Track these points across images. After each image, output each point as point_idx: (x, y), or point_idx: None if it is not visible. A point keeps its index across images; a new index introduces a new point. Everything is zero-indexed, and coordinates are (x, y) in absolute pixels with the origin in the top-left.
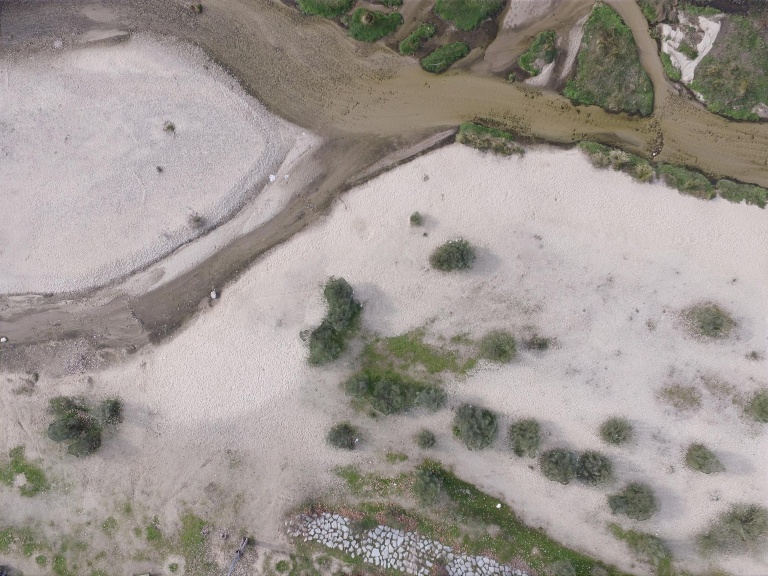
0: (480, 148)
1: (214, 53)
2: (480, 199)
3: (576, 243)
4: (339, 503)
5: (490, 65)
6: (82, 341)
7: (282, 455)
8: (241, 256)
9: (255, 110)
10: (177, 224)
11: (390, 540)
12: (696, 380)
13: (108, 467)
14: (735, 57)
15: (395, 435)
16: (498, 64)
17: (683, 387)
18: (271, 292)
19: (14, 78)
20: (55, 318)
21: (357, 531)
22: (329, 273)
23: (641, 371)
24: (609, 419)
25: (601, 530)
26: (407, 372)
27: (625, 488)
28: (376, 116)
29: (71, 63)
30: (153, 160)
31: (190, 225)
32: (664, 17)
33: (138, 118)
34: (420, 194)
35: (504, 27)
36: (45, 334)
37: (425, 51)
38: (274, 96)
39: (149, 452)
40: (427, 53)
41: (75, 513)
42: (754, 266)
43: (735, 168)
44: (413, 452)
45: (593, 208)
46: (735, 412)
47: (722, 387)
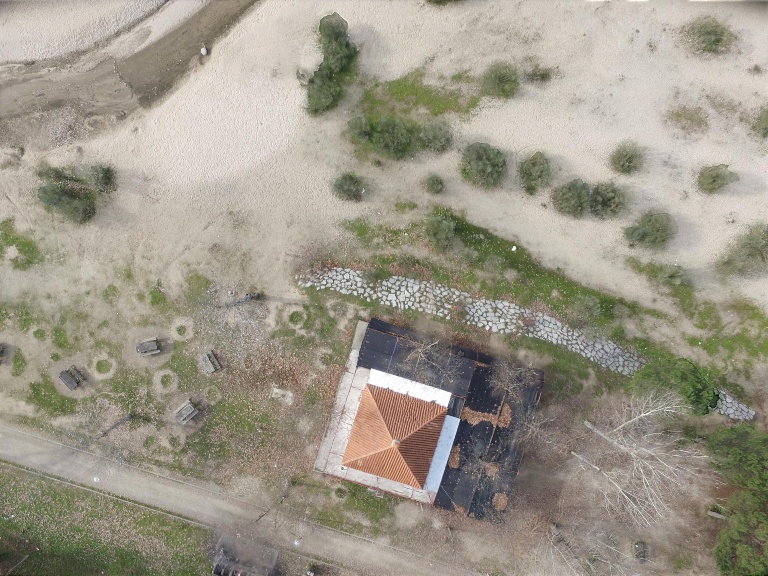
0: None
1: None
2: None
3: None
4: (350, 258)
5: None
6: (68, 110)
7: (287, 213)
8: (230, 10)
9: None
10: None
11: (405, 287)
12: (702, 99)
13: (105, 235)
14: None
15: (402, 183)
16: None
17: (690, 108)
18: (264, 42)
19: None
20: (38, 88)
21: (371, 281)
22: (322, 17)
23: (646, 95)
24: (618, 148)
25: (619, 265)
26: (410, 116)
27: (640, 219)
28: None
29: None
30: None
31: None
32: None
33: None
34: None
35: None
36: (29, 106)
37: None
38: None
39: (147, 218)
40: None
41: (72, 284)
42: None
43: None
44: (422, 200)
45: None
46: (743, 130)
47: (728, 105)
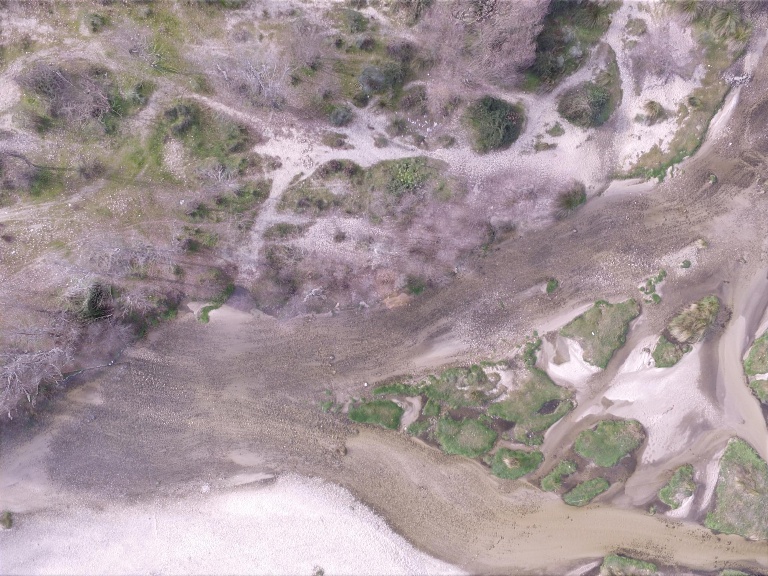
0: None
1: (359, 494)
2: None
3: None
4: None
5: (631, 499)
6: None
7: None
8: None
9: (402, 549)
10: None
11: None
12: None
13: None
14: None
15: None
16: (639, 498)
17: None
18: None
19: (162, 525)
20: None
21: None
22: None
23: None
24: None
25: None
26: None
27: None
28: (521, 550)
29: (218, 508)
30: None
31: None
32: None
33: (287, 564)
34: None
35: (643, 462)
36: None
37: (567, 487)
38: (419, 533)
39: None
40: (569, 489)
41: None
42: None
43: None
44: None
45: None
46: None
47: None
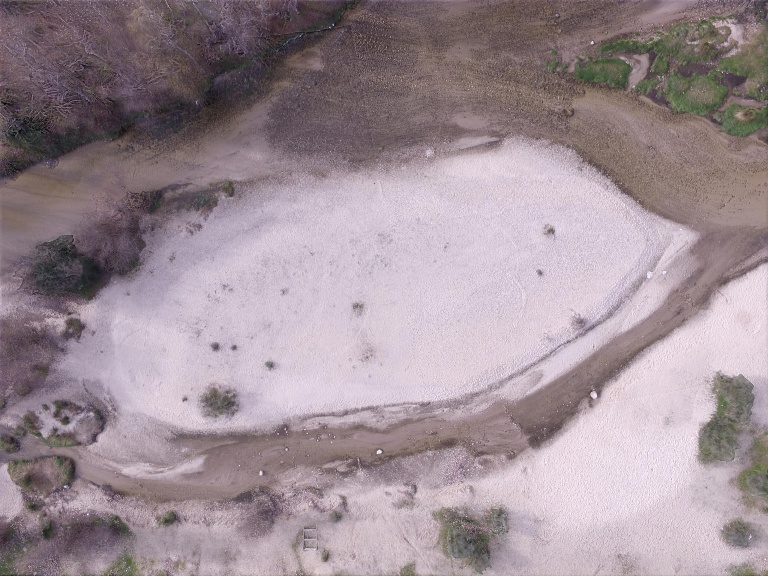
0: None
1: (587, 154)
2: None
3: None
4: None
5: None
6: (460, 449)
7: (674, 557)
8: (619, 354)
9: (632, 209)
10: (559, 326)
11: None
12: None
13: None
14: None
15: None
16: None
17: None
18: (656, 390)
19: (388, 189)
20: (431, 427)
21: None
22: (715, 368)
23: None
24: None
25: None
26: None
27: None
28: (752, 208)
29: (444, 171)
30: (533, 264)
31: (573, 327)
32: None
33: (517, 223)
34: None
35: None
36: (421, 444)
37: None
38: (649, 194)
39: (539, 561)
40: None
41: None
42: None
43: None
44: None
45: None
46: None
47: None
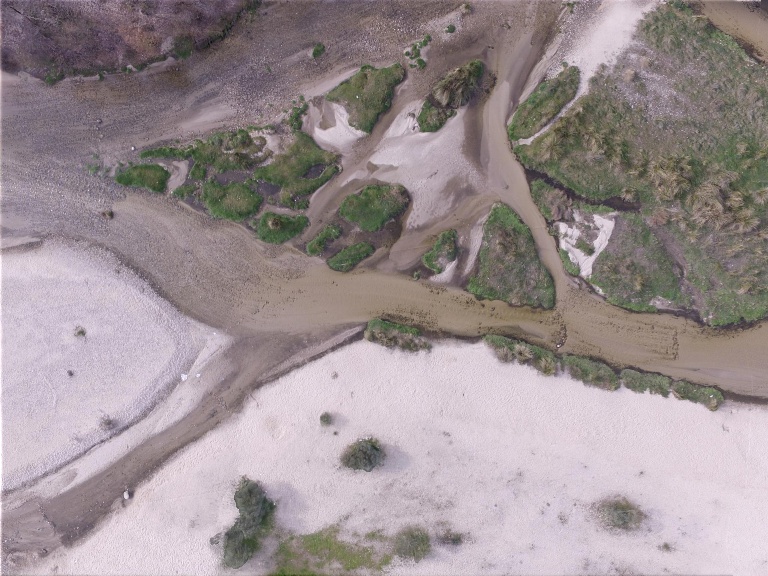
0: (387, 346)
1: (125, 257)
2: (389, 396)
3: (484, 439)
4: None
5: (395, 264)
6: None
7: None
8: (154, 455)
9: (166, 312)
10: (88, 427)
11: None
12: (611, 572)
13: None
14: (630, 253)
15: None
16: (403, 263)
17: None
18: (184, 492)
19: None
20: None
21: None
22: (241, 472)
23: (556, 564)
24: None
25: None
26: (322, 570)
27: None
28: (286, 314)
29: None
30: (64, 364)
31: (101, 428)
32: (560, 217)
33: (49, 324)
34: (330, 392)
35: (407, 227)
36: None
37: (332, 251)
38: (185, 297)
39: None
40: (334, 253)
41: None
42: (660, 457)
43: (638, 357)
44: None
45: (500, 403)
46: None
47: None
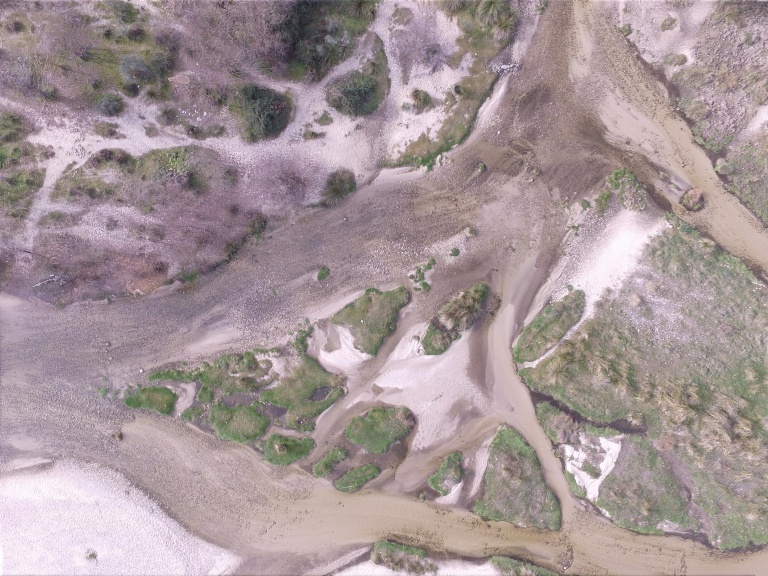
0: None
1: (135, 478)
2: None
3: None
4: None
5: (401, 485)
6: None
7: None
8: None
9: (175, 533)
10: None
11: None
12: None
13: None
14: (637, 476)
15: None
16: (409, 484)
17: None
18: None
19: None
20: None
21: None
22: None
23: None
24: None
25: None
26: None
27: None
28: (293, 535)
29: None
30: None
31: None
32: (566, 440)
33: (61, 546)
34: None
35: (413, 449)
36: None
37: (338, 473)
38: (193, 518)
39: None
40: (340, 475)
41: None
42: None
43: None
44: None
45: None
46: None
47: None
